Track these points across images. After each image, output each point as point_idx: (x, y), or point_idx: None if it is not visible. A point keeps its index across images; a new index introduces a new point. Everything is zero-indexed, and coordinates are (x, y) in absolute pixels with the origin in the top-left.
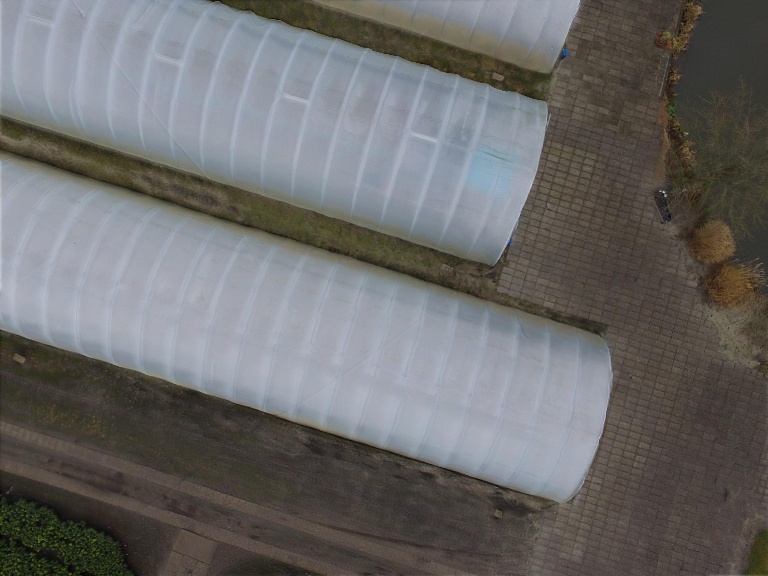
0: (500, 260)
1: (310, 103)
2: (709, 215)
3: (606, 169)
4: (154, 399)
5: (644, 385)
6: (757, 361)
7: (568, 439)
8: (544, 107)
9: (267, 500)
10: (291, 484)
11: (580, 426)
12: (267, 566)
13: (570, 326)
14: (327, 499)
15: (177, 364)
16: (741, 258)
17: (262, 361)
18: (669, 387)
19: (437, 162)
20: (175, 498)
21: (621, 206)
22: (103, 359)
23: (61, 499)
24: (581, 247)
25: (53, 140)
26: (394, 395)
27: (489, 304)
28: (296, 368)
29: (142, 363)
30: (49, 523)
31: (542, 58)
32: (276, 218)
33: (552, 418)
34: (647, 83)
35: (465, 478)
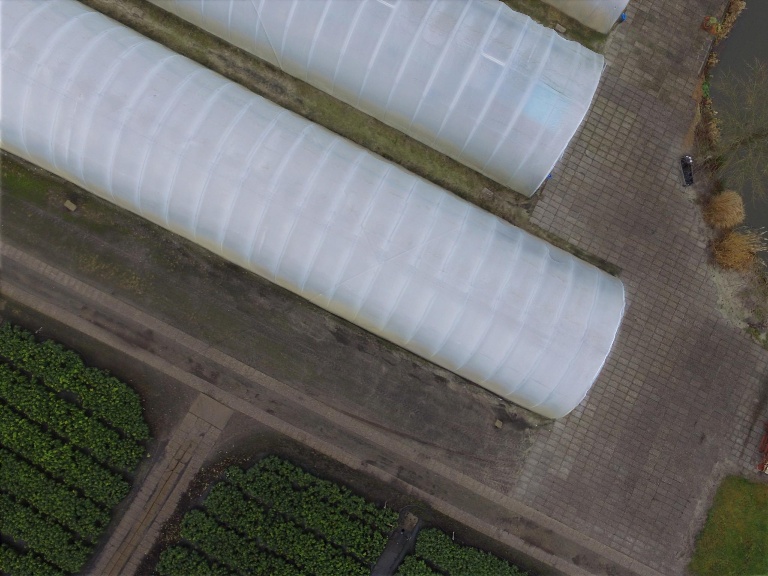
0: (536, 193)
1: (396, 9)
2: (726, 185)
3: (643, 129)
4: (195, 266)
5: (646, 328)
6: (747, 323)
7: (579, 352)
8: (601, 57)
9: (287, 378)
10: (312, 366)
11: (591, 342)
12: (277, 440)
13: (590, 263)
14: (344, 386)
15: (230, 228)
16: (749, 225)
17: (313, 236)
18: (668, 333)
19: (501, 84)
20: (200, 362)
21: (650, 164)
22: (155, 217)
23: (88, 346)
24: (610, 195)
25: (139, 6)
26: (429, 287)
27: (521, 229)
28: (344, 247)
29: (196, 223)
30: (74, 366)
31: (604, 17)
32: (339, 118)
33: (567, 331)
34: (690, 60)
35: (474, 386)
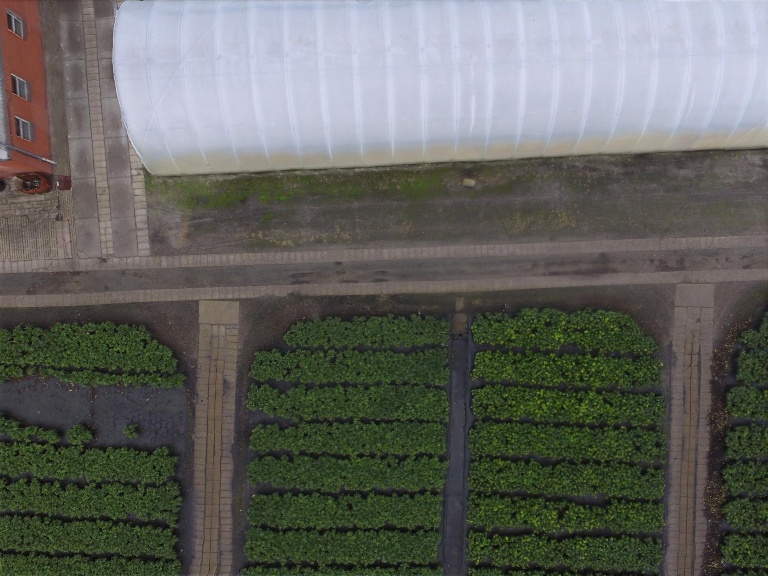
0: None
1: None
2: None
3: None
4: (605, 176)
5: None
6: None
7: None
8: None
9: (744, 229)
10: (760, 207)
11: None
12: (766, 289)
13: None
14: None
15: (656, 107)
16: None
17: (743, 68)
18: None
19: None
20: (660, 258)
21: None
22: (558, 147)
23: (555, 298)
24: None
25: None
26: None
27: None
28: None
29: (615, 123)
30: (559, 319)
31: None
32: None
33: None
34: None
35: None
